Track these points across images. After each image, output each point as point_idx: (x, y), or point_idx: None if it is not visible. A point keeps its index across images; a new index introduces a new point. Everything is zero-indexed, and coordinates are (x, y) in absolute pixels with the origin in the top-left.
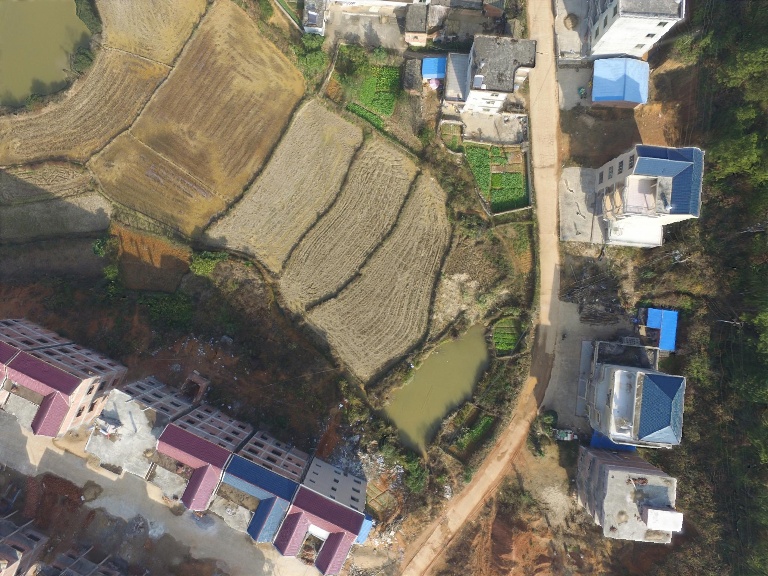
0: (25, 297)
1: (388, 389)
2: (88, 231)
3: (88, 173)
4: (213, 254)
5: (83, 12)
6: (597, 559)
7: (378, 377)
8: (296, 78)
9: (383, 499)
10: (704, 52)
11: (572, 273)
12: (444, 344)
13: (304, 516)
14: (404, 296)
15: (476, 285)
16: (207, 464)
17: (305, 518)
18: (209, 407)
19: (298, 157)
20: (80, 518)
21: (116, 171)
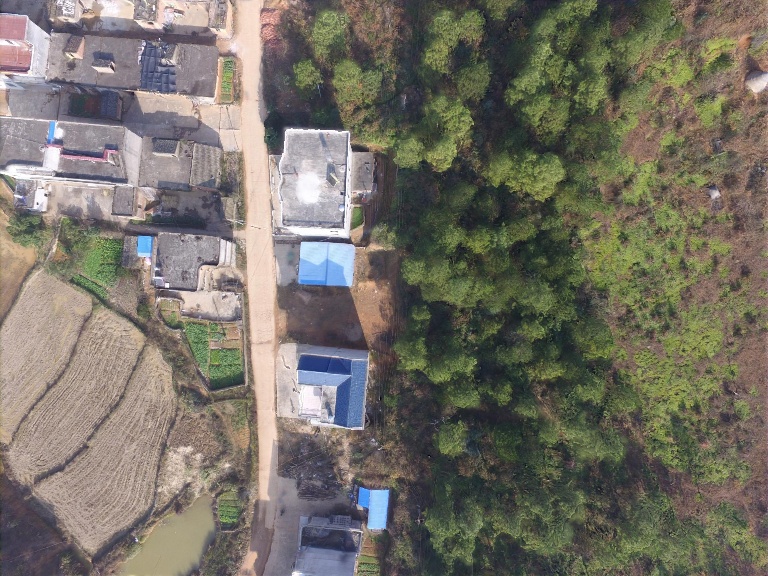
0: None
1: (111, 564)
2: None
3: None
4: None
5: None
6: None
7: (105, 550)
8: (28, 246)
9: None
10: None
11: (289, 449)
12: None
13: None
14: (131, 468)
15: (200, 458)
16: None
17: None
18: None
19: (28, 327)
20: None
21: None
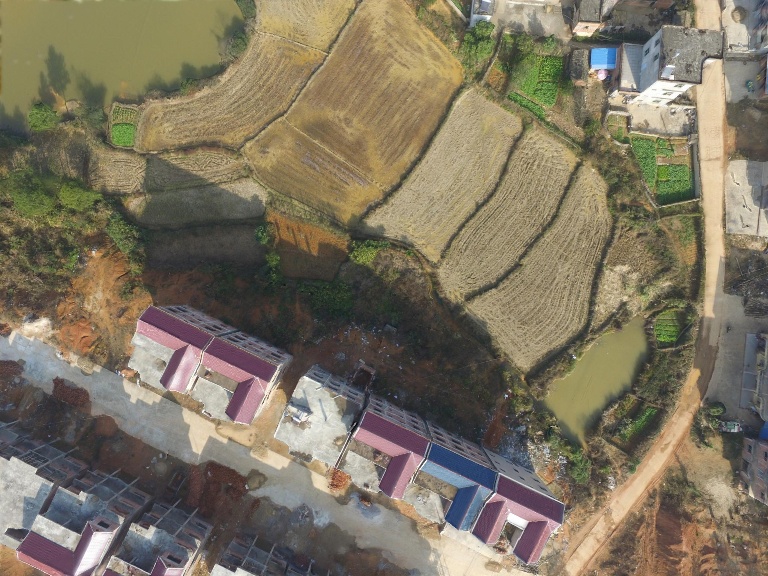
0: (184, 284)
1: (551, 380)
2: (242, 218)
3: (242, 159)
4: (375, 242)
5: None
6: (760, 550)
7: (539, 368)
8: (454, 66)
9: (550, 489)
10: None
11: (737, 266)
12: (604, 335)
13: (505, 505)
14: (565, 287)
15: (638, 277)
16: (408, 452)
17: (506, 507)
18: (376, 396)
19: (457, 146)
20: (244, 507)
21: (271, 158)
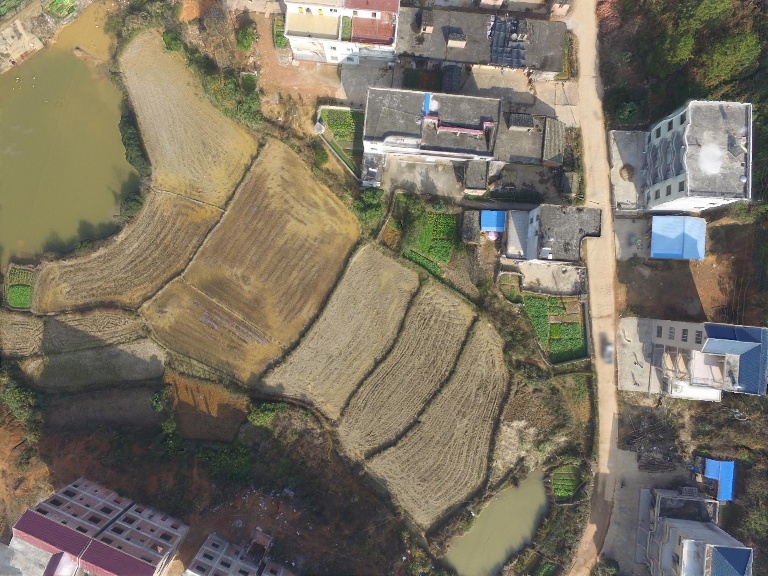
0: (81, 453)
1: (450, 538)
2: (141, 379)
3: (140, 319)
4: (272, 405)
5: (134, 159)
6: None
7: (439, 525)
8: (350, 221)
9: None
10: (762, 215)
11: (630, 422)
12: (503, 490)
13: None
14: (463, 443)
15: (535, 432)
16: None
17: None
18: (273, 565)
19: (354, 303)
20: None
21: (169, 317)
